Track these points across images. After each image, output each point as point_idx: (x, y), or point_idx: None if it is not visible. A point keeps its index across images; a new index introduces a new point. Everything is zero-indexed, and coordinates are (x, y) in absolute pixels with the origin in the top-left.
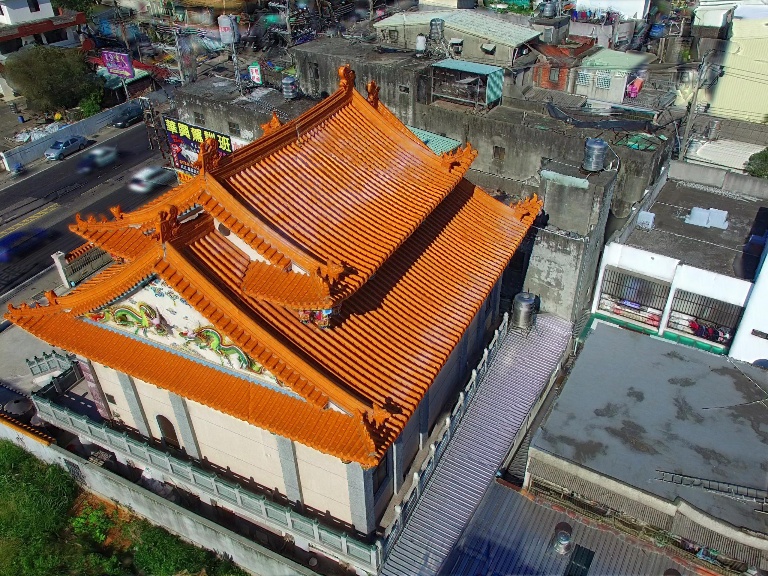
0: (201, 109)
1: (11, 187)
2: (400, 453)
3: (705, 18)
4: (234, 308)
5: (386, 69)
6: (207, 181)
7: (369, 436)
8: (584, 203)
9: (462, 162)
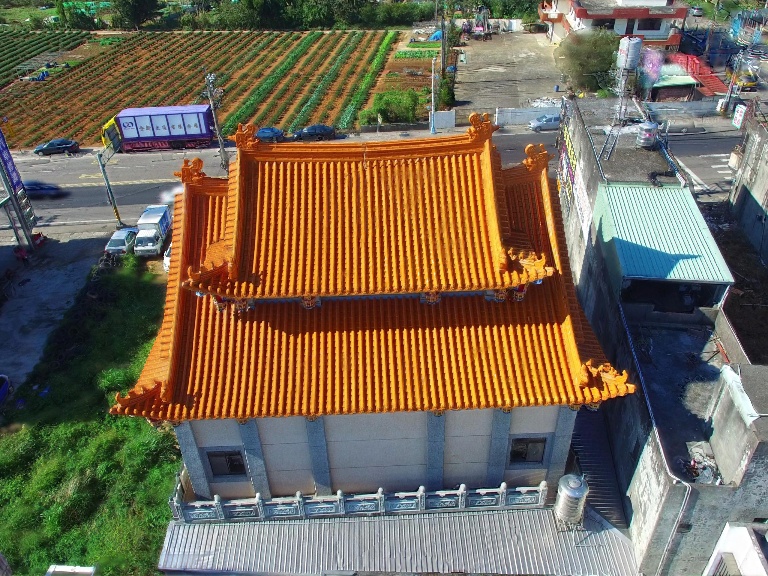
0: None
1: None
2: (259, 466)
3: None
4: (181, 252)
5: None
6: None
7: None
8: (740, 444)
9: (527, 271)
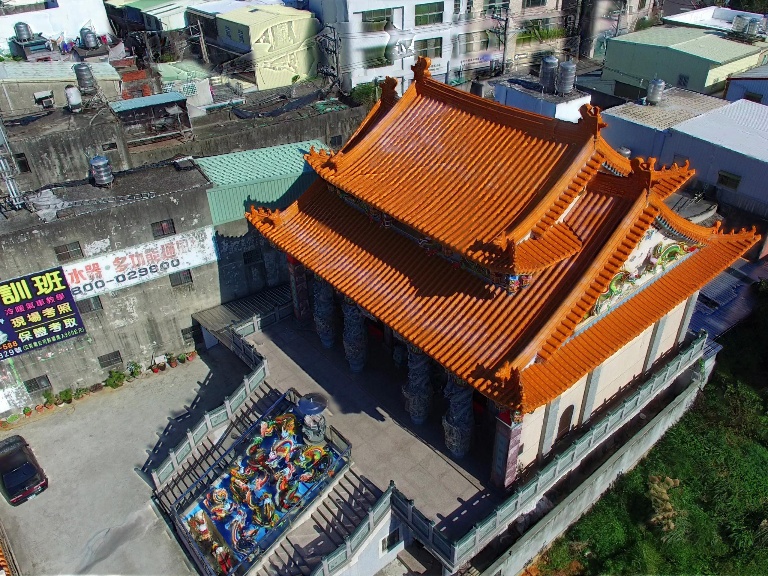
0: None
1: None
2: None
3: (171, 23)
4: None
5: (76, 133)
6: (599, 140)
7: None
8: None
9: None
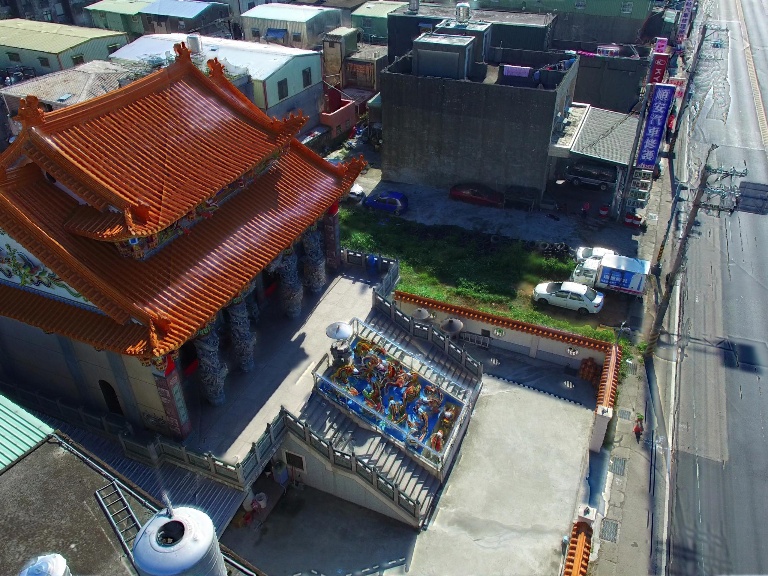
0: None
1: None
2: None
3: None
4: None
5: None
6: None
7: None
8: None
9: None
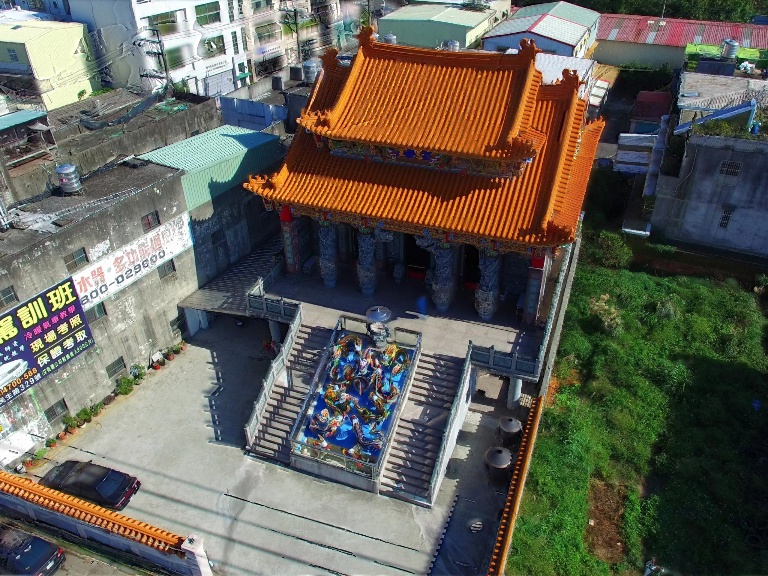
0: (8, 279)
1: None
2: None
3: None
4: None
5: None
6: None
7: None
8: None
9: None
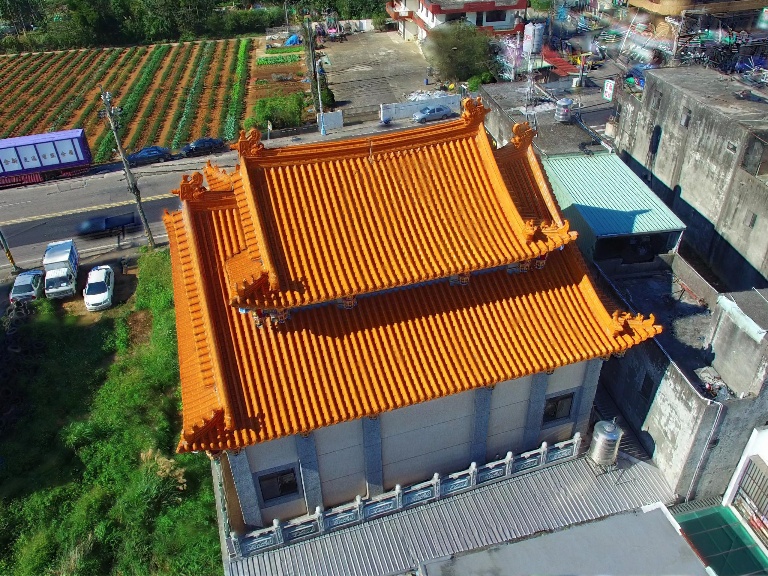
0: None
1: (371, 134)
2: (314, 480)
3: None
4: (199, 273)
5: (721, 118)
6: None
7: (192, 427)
8: (752, 360)
9: (552, 239)
